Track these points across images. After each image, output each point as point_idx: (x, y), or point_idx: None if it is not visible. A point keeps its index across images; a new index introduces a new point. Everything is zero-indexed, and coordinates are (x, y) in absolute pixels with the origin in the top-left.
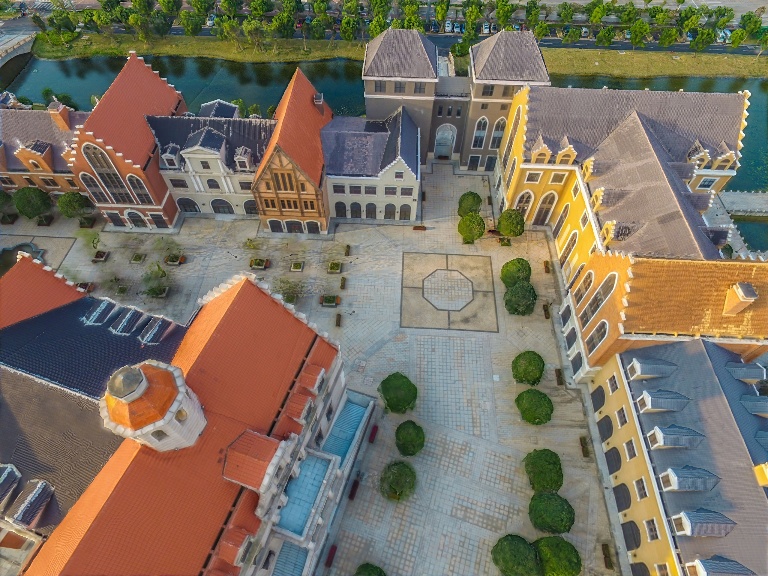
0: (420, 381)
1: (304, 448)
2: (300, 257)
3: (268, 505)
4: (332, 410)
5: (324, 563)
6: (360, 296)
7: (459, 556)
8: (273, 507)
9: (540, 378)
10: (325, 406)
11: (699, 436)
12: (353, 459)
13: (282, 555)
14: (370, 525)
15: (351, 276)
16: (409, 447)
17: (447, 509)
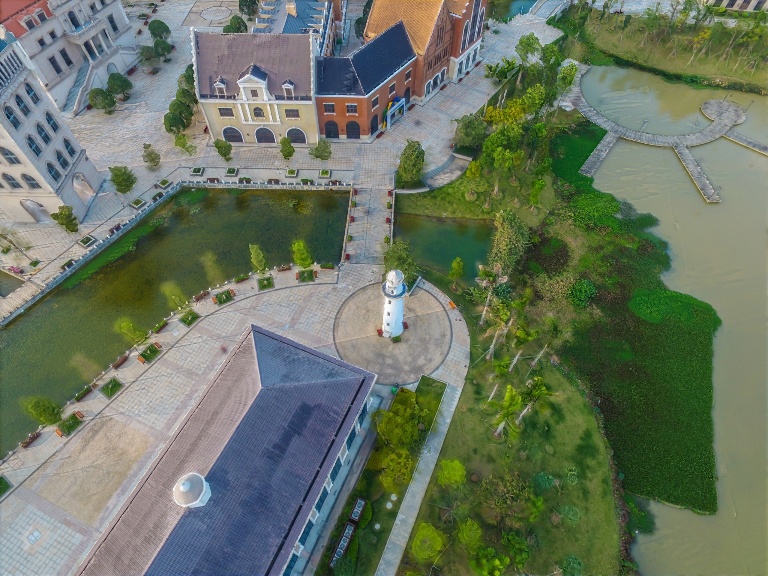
0: (183, 42)
1: (87, 15)
2: (133, 3)
3: (55, 8)
4: (118, 28)
5: (107, 90)
6: (163, 16)
7: (176, 89)
8: (58, 8)
9: (241, 29)
10: (104, 8)
11: (278, 10)
12: (134, 62)
13: (80, 72)
14: (135, 82)
15: (161, 9)
16: (159, 49)
17: (177, 77)
